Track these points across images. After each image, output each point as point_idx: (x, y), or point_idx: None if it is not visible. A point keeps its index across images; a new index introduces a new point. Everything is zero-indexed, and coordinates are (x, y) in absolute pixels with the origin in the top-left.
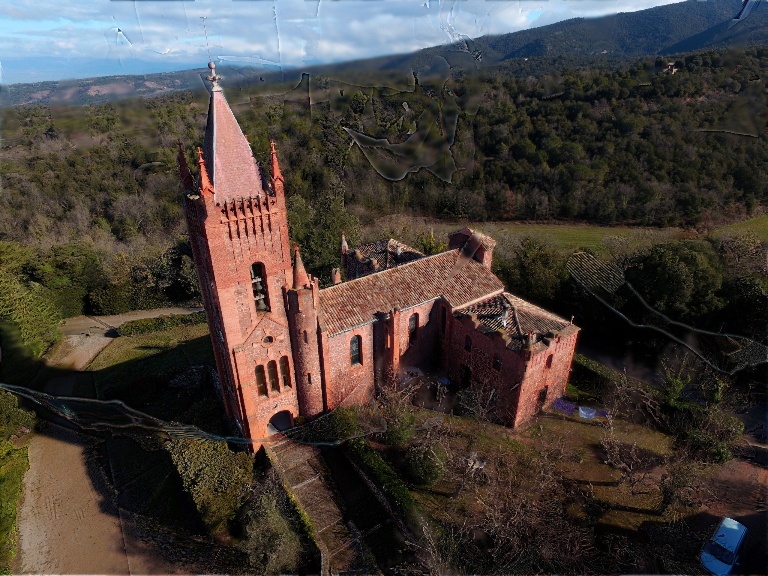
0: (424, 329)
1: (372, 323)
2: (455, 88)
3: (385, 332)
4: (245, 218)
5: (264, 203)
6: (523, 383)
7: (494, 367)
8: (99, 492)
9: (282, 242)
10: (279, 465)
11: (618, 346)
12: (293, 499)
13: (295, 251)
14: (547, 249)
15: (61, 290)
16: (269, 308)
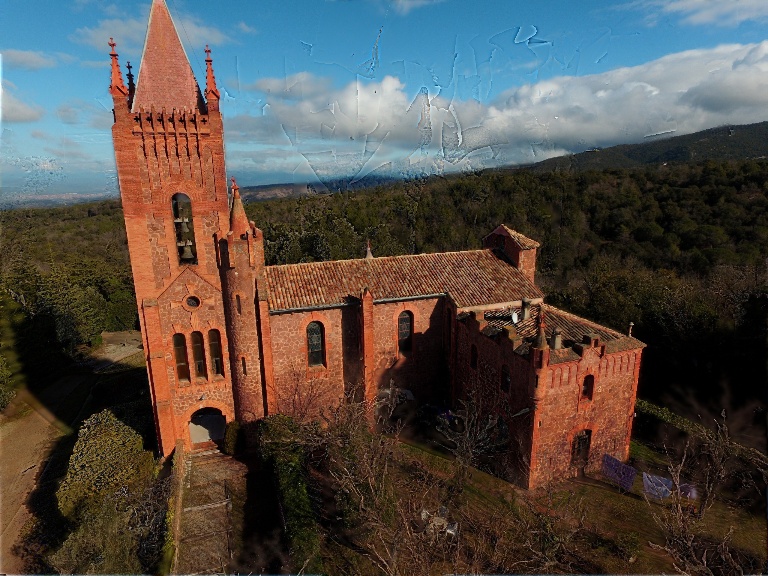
0: (423, 338)
1: (340, 310)
2: (544, 135)
3: (358, 325)
4: (164, 132)
5: (192, 120)
6: (537, 409)
7: (502, 388)
8: (20, 484)
9: (215, 174)
10: (179, 474)
11: (739, 413)
12: (170, 520)
13: (234, 191)
14: None
15: (120, 303)
16: (197, 260)
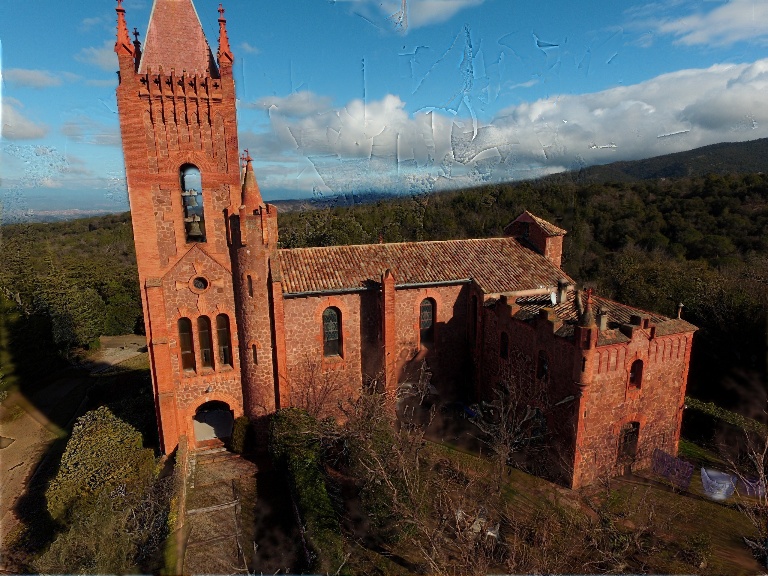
0: (446, 328)
1: (359, 295)
2: (553, 138)
3: (378, 312)
4: (173, 96)
5: (204, 84)
6: (582, 397)
7: (539, 377)
8: (7, 488)
9: (227, 144)
10: (183, 472)
11: None
12: (172, 522)
13: None
14: (655, 264)
15: (120, 306)
16: (206, 237)
